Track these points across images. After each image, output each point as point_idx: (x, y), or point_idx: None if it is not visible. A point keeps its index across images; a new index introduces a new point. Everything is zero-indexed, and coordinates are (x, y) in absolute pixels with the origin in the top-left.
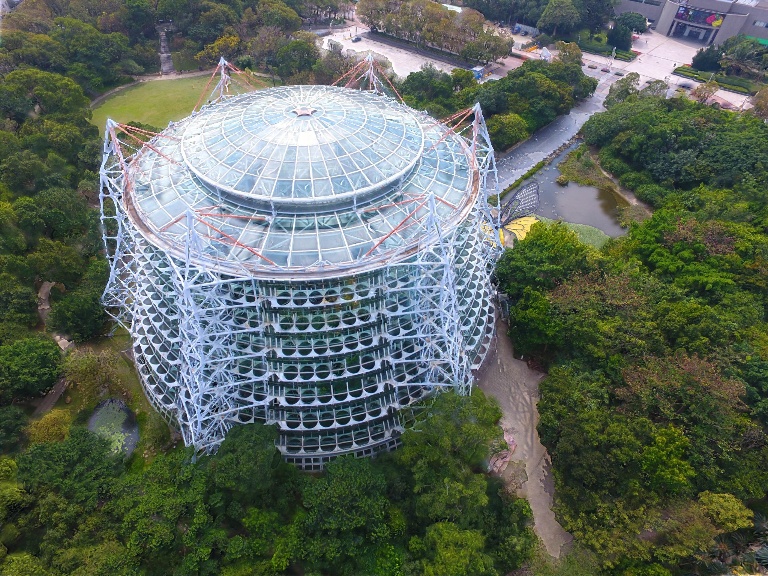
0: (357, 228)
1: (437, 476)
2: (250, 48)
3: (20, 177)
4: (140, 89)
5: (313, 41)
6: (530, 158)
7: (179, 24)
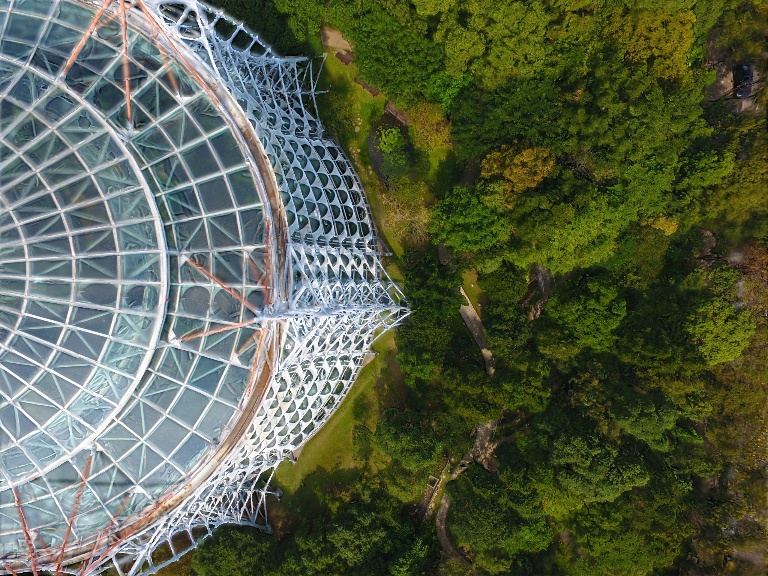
0: None
1: None
2: None
3: None
4: None
5: None
6: None
7: None
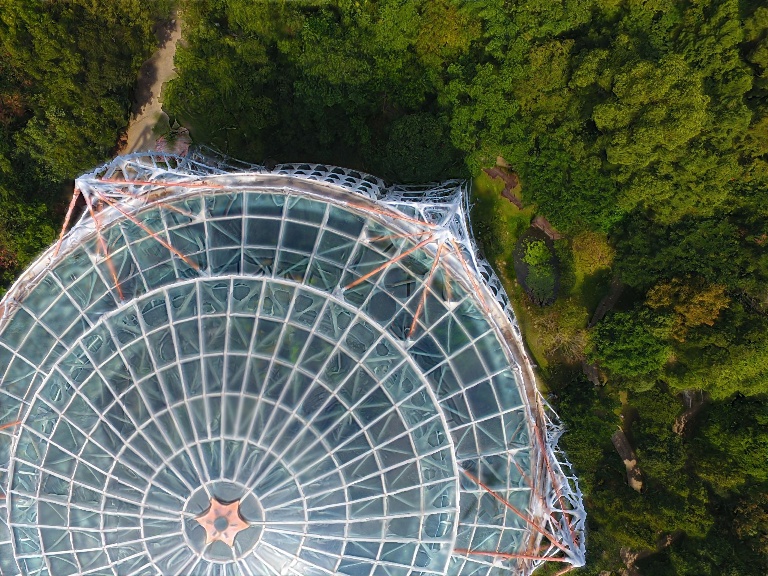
0: (219, 248)
1: (245, 72)
2: None
3: None
4: None
5: None
6: None
7: None
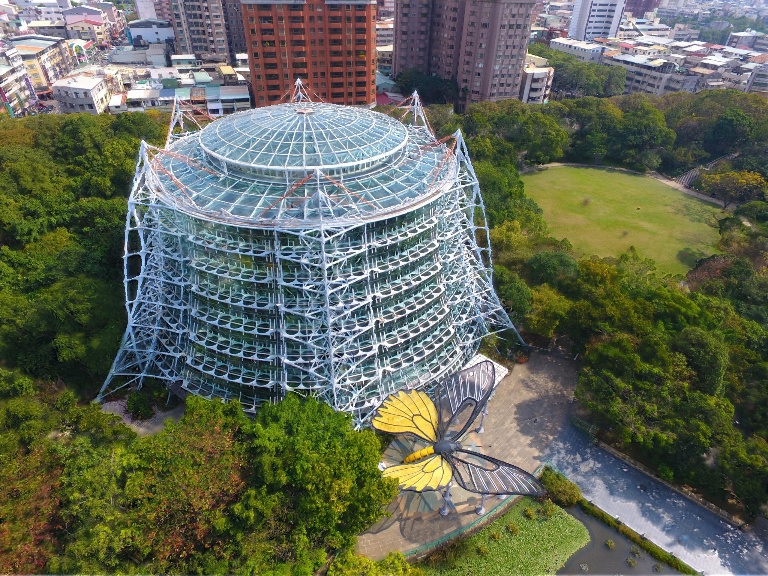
0: None
1: None
2: None
3: None
4: (630, 177)
5: None
6: None
7: None
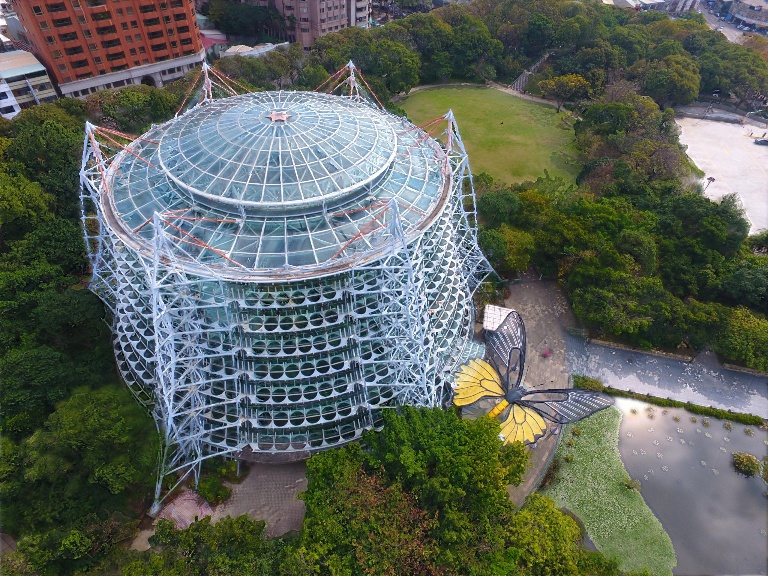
0: None
1: None
2: (592, 95)
3: None
4: (477, 91)
5: (646, 112)
6: (749, 400)
7: (557, 51)
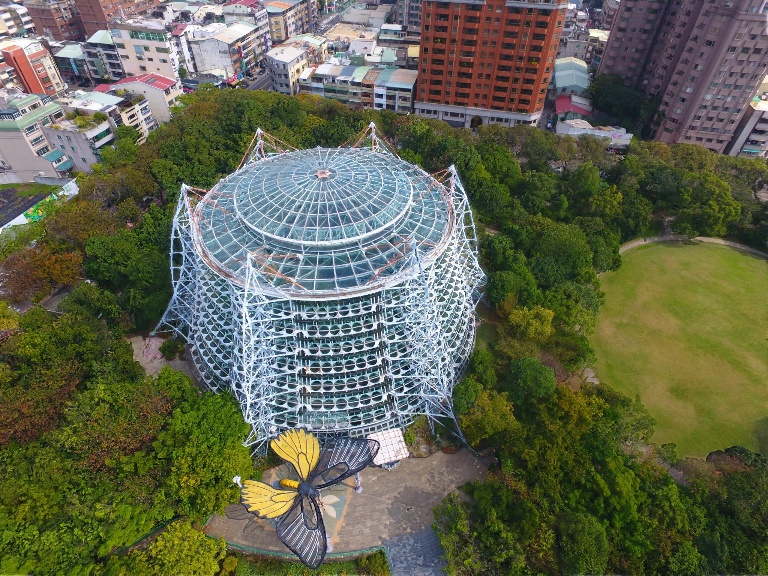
0: None
1: None
2: None
3: (526, 182)
4: None
5: None
6: None
7: None
